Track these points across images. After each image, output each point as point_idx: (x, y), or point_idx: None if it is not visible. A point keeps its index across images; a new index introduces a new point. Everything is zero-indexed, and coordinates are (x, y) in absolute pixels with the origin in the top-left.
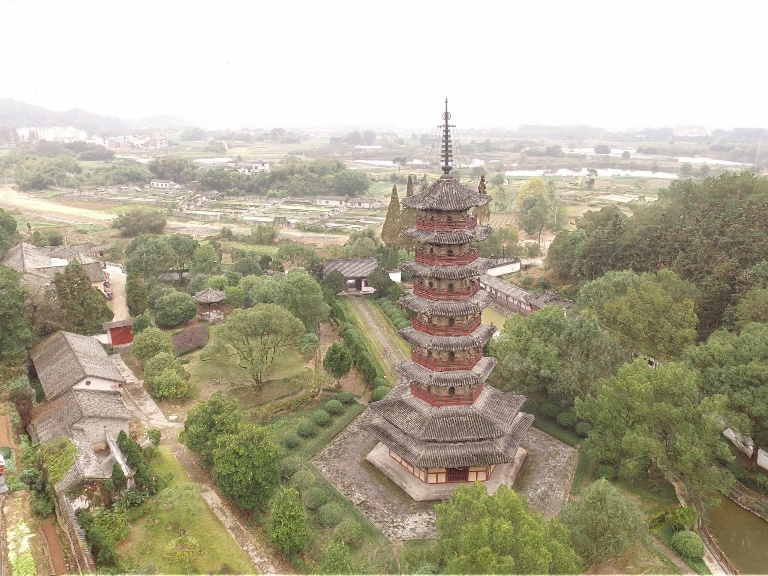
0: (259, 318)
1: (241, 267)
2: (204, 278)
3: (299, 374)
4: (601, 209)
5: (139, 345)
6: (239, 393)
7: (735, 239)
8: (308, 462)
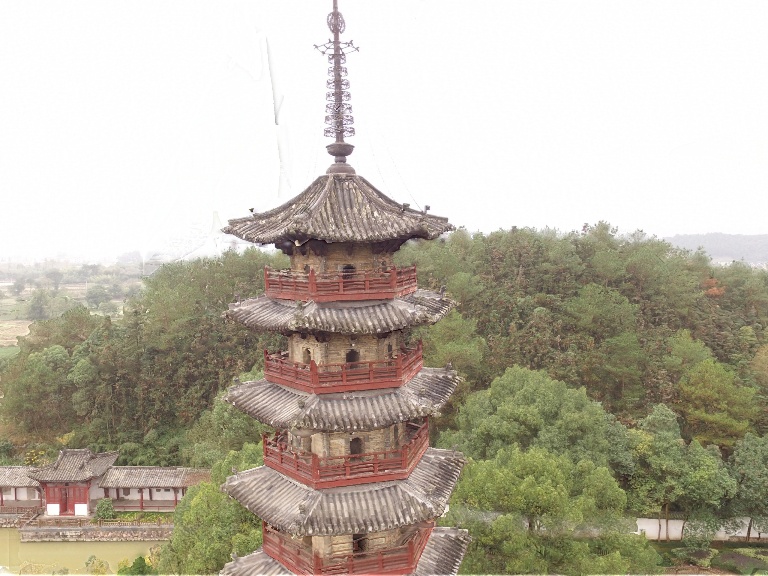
0: None
1: None
2: None
3: None
4: (63, 314)
5: None
6: None
7: None
8: None
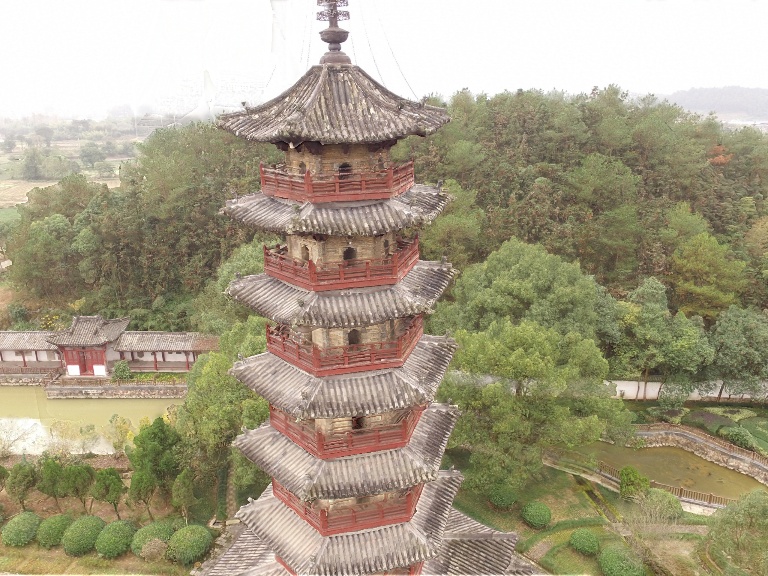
0: None
1: None
2: None
3: None
4: (60, 181)
5: None
6: None
7: None
8: None
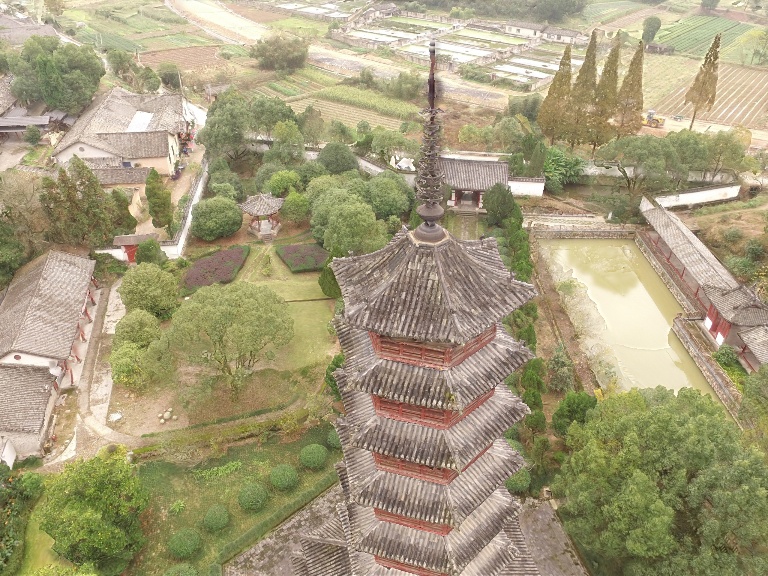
0: (212, 321)
1: (326, 155)
2: (272, 170)
3: (309, 366)
4: None
5: (123, 289)
6: (217, 387)
7: None
8: (221, 568)
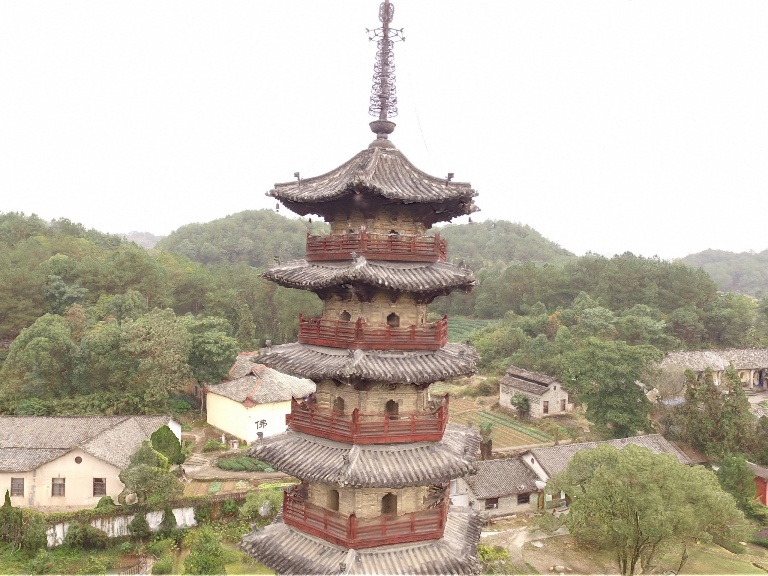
0: (594, 455)
1: None
2: None
3: None
4: None
5: None
6: None
7: None
8: None
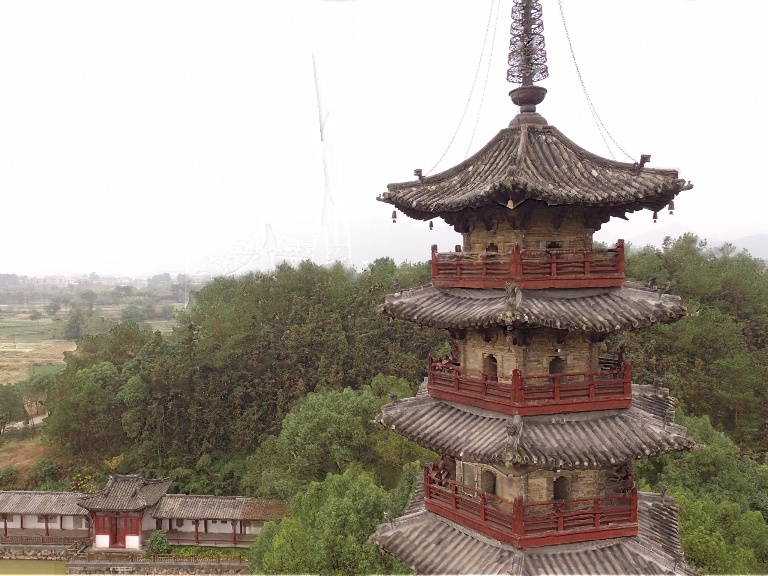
0: None
1: None
2: None
3: None
4: (112, 329)
5: None
6: None
7: (384, 329)
8: None
